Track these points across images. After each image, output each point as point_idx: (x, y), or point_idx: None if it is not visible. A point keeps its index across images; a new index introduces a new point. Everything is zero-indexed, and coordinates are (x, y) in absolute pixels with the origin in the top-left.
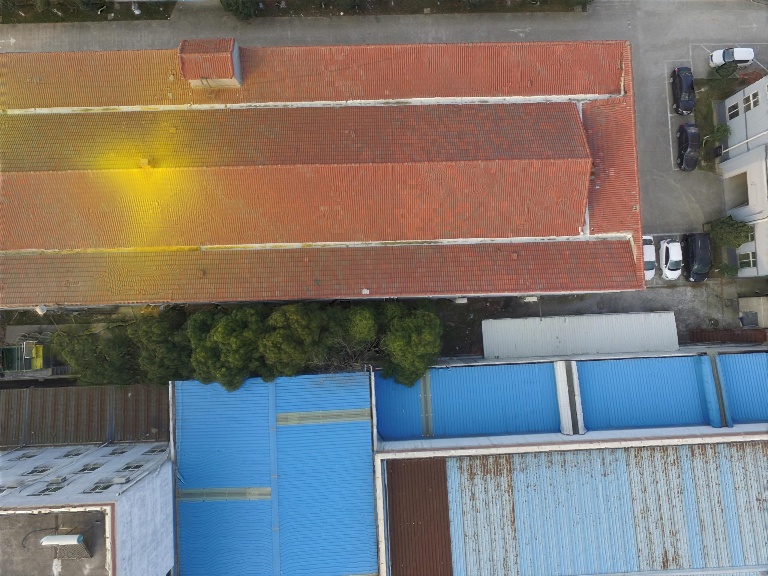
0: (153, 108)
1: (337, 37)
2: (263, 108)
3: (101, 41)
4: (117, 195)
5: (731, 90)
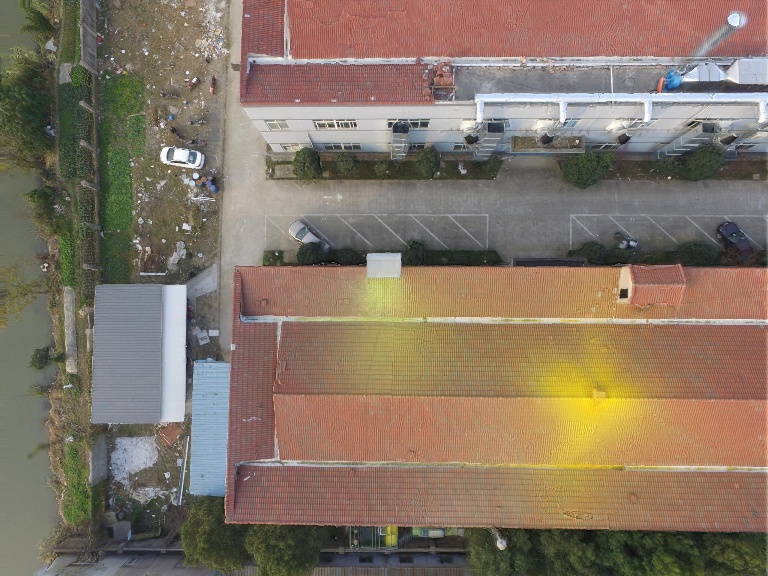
0: (573, 320)
1: (665, 202)
2: (686, 324)
3: (427, 200)
4: (558, 420)
5: None
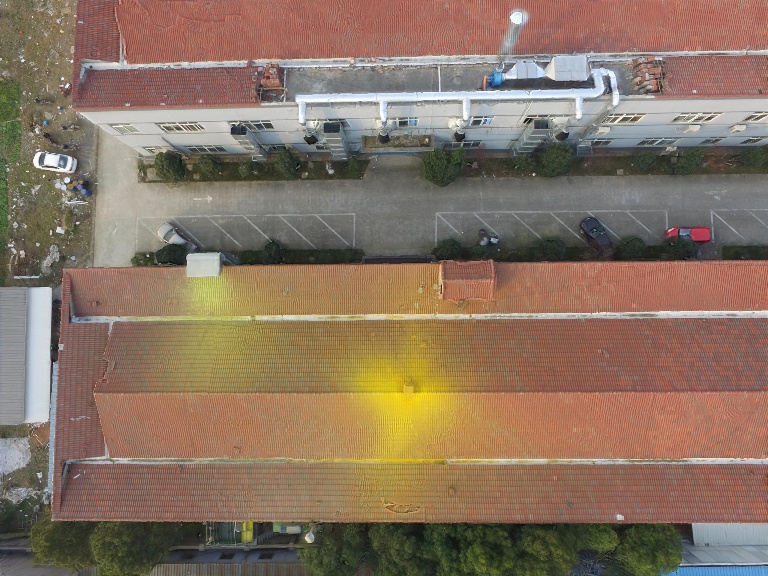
0: (398, 317)
1: (529, 198)
2: (508, 319)
3: (295, 200)
4: (374, 414)
5: None
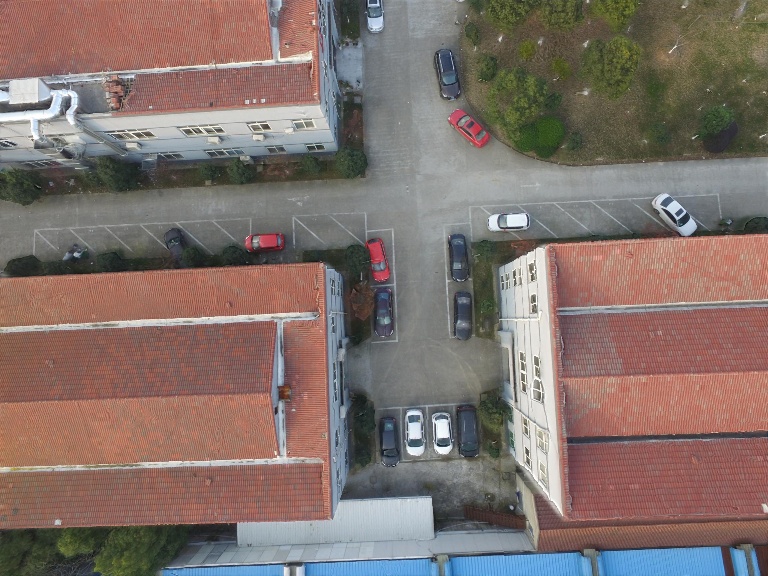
0: None
1: (121, 212)
2: None
3: None
4: None
5: (508, 255)
